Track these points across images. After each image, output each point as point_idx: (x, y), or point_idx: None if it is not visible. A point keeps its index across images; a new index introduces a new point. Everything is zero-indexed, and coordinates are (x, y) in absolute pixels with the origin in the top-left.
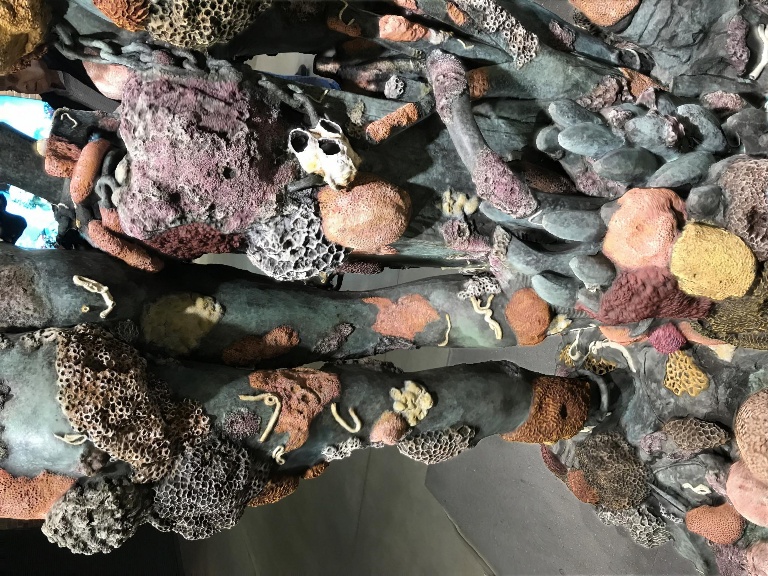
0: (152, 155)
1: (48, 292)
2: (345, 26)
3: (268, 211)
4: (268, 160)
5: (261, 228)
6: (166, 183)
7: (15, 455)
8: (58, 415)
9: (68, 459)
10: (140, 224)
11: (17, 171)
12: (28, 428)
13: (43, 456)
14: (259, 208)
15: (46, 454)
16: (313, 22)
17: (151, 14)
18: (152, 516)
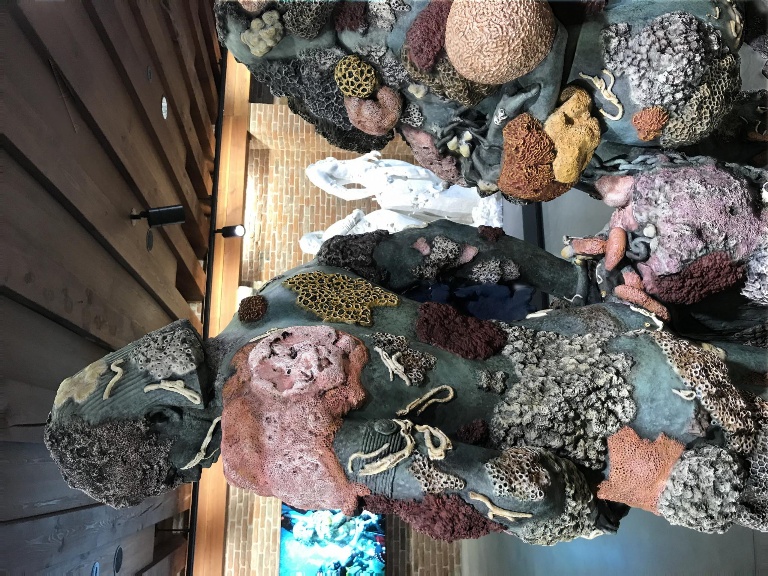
0: (676, 209)
1: (619, 315)
2: (761, 136)
3: (765, 238)
4: (753, 205)
5: (761, 255)
6: (692, 223)
7: (641, 416)
8: (672, 375)
9: (683, 416)
10: (677, 256)
11: (549, 273)
12: (652, 386)
13: (664, 414)
14: (758, 237)
15: (666, 411)
16: (733, 143)
17: (669, 119)
18: (742, 504)
